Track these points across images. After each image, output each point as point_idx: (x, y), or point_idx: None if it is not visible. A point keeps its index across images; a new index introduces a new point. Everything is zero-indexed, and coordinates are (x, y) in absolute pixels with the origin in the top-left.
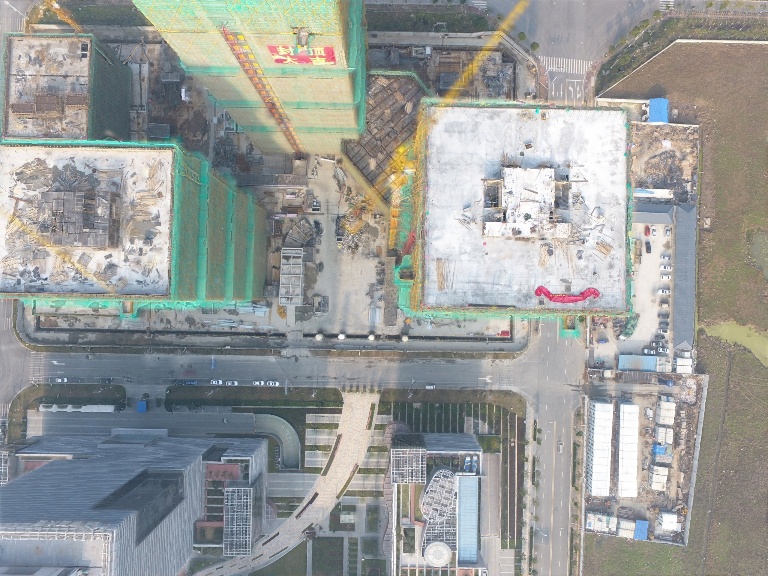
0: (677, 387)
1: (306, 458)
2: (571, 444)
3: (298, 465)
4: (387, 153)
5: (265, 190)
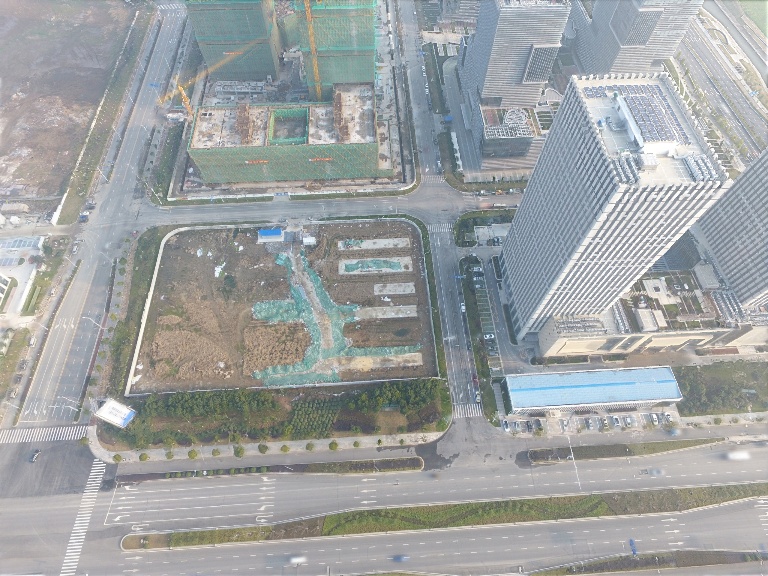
0: None
1: None
2: None
3: None
4: (284, 8)
5: (302, 79)
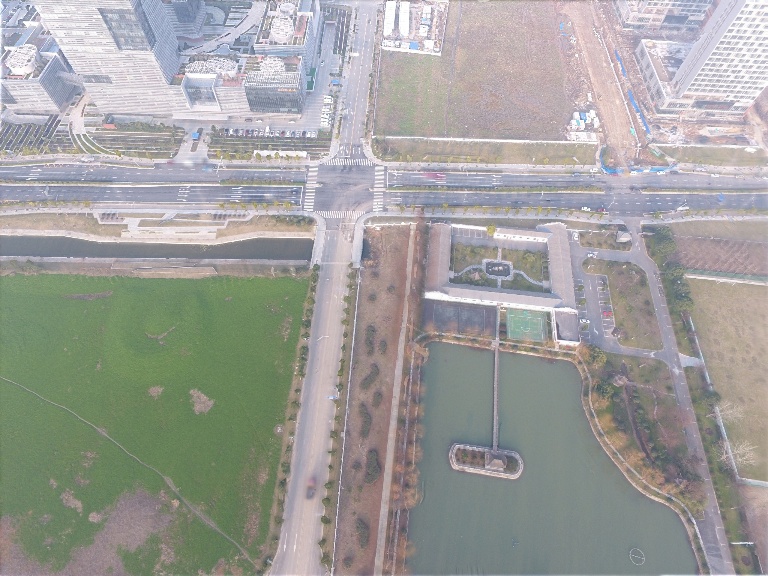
0: (433, 5)
1: (227, 22)
2: (376, 21)
3: (222, 22)
4: None
5: None
